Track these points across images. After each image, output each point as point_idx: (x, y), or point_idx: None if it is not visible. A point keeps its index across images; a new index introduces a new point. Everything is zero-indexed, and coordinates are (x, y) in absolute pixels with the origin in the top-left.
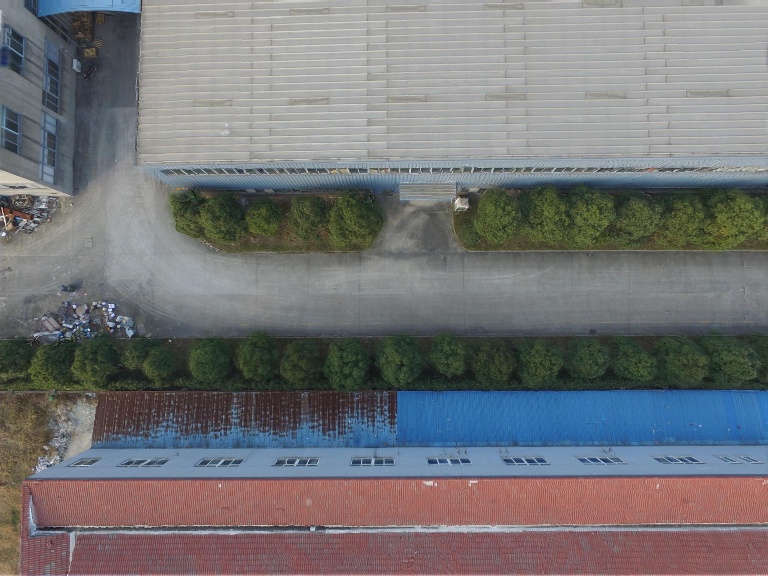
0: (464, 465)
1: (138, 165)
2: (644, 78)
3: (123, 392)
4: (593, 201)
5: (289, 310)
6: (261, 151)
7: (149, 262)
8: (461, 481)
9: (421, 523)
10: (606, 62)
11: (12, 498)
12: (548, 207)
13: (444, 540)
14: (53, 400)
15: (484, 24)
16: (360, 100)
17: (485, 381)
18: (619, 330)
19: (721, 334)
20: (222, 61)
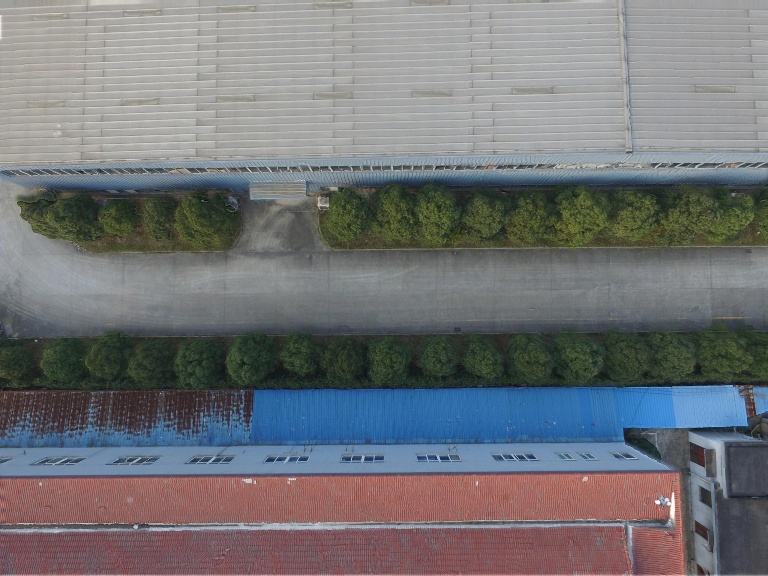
0: (298, 463)
1: None
2: (470, 76)
3: None
4: (434, 199)
5: (155, 310)
6: (92, 151)
7: (17, 263)
8: (280, 479)
9: (241, 521)
10: (436, 60)
11: None
12: (388, 205)
13: (270, 538)
14: None
15: (312, 23)
16: (190, 100)
17: (332, 379)
18: (483, 328)
19: (583, 331)
20: (56, 62)
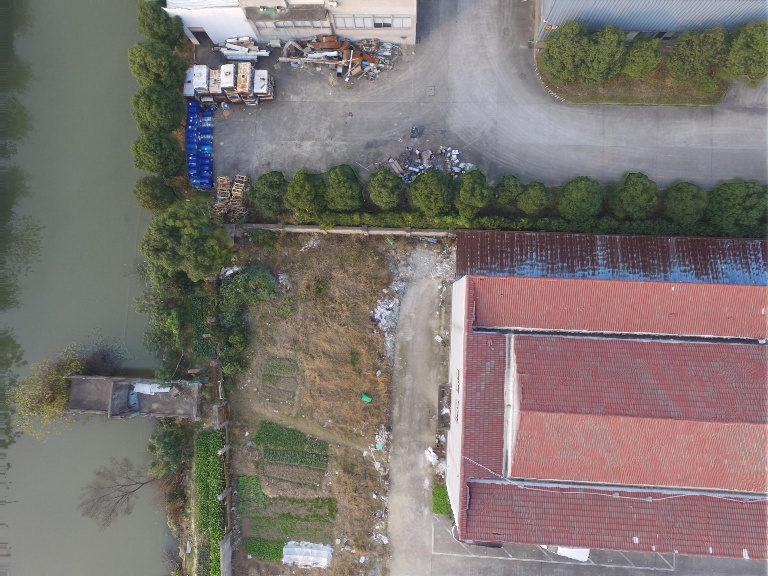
0: None
1: (481, 15)
2: None
3: (482, 231)
4: None
5: (637, 162)
6: None
7: (492, 111)
8: None
9: None
10: None
11: (352, 339)
12: None
13: None
14: (393, 244)
15: None
16: None
17: None
18: None
19: None
20: None
